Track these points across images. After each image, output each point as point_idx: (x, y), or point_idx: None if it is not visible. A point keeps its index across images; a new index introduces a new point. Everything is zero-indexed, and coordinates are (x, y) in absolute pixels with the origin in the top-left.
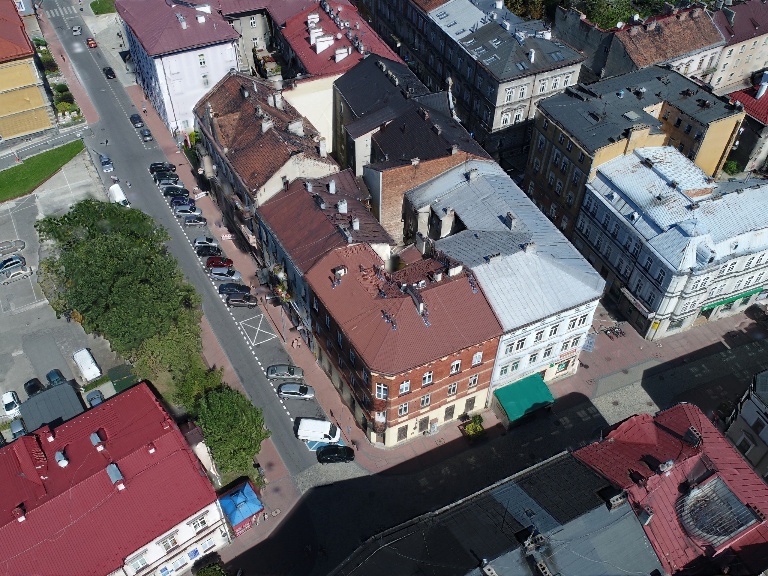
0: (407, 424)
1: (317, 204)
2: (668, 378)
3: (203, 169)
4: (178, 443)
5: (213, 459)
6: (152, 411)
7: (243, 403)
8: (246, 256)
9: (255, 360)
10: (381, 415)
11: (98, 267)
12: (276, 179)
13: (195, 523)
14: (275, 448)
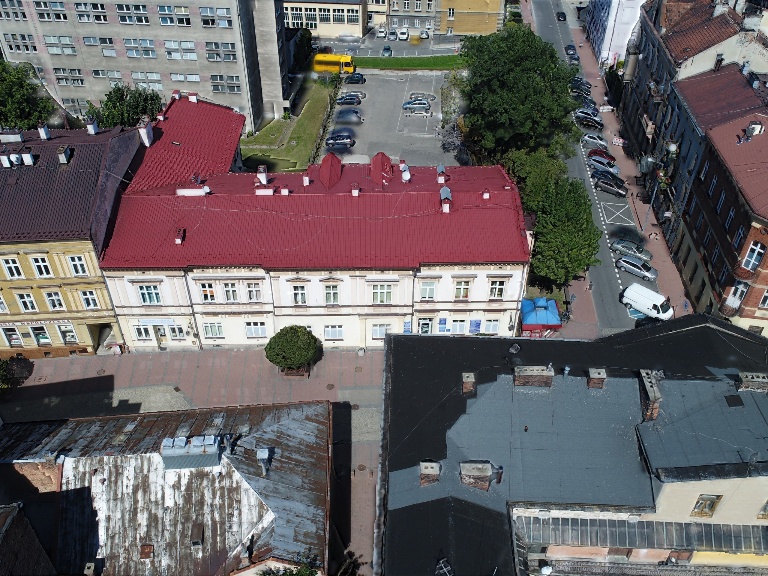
0: (763, 326)
1: (749, 83)
2: None
3: (624, 71)
4: (513, 203)
5: (532, 258)
6: (499, 179)
7: (588, 211)
8: (631, 161)
9: (603, 232)
10: (737, 296)
11: (507, 48)
12: (710, 54)
13: (493, 285)
14: (592, 300)
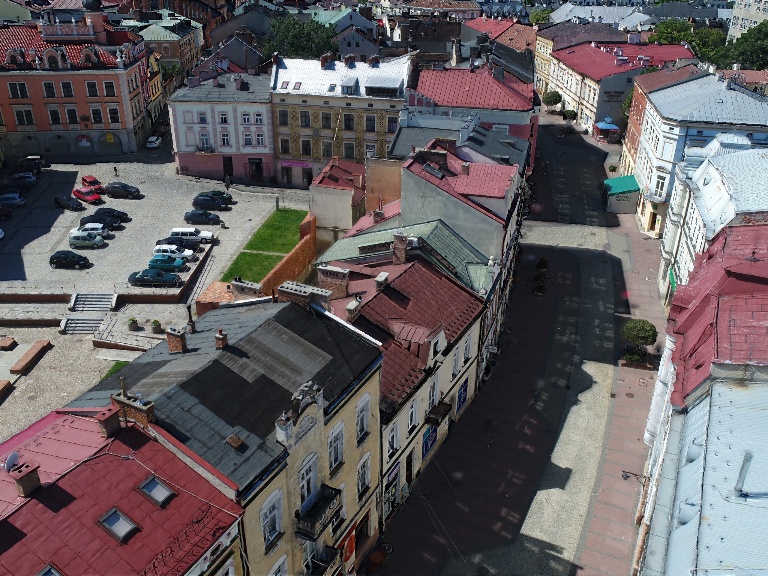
0: None
1: None
2: (602, 264)
3: None
4: None
5: None
6: None
7: None
8: None
9: None
10: None
11: None
12: None
13: None
14: None
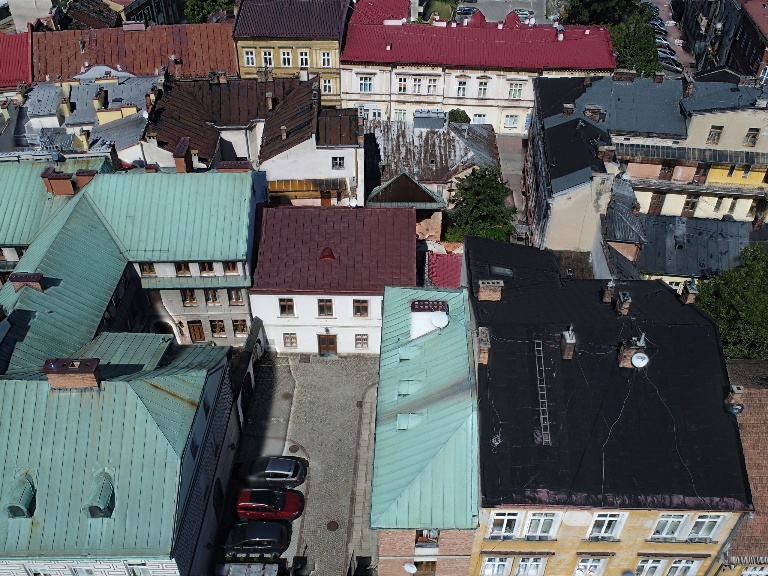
0: None
1: None
2: None
3: None
4: (605, 37)
5: None
6: None
7: (655, 50)
8: (688, 54)
9: None
10: None
11: None
12: None
13: None
14: None
